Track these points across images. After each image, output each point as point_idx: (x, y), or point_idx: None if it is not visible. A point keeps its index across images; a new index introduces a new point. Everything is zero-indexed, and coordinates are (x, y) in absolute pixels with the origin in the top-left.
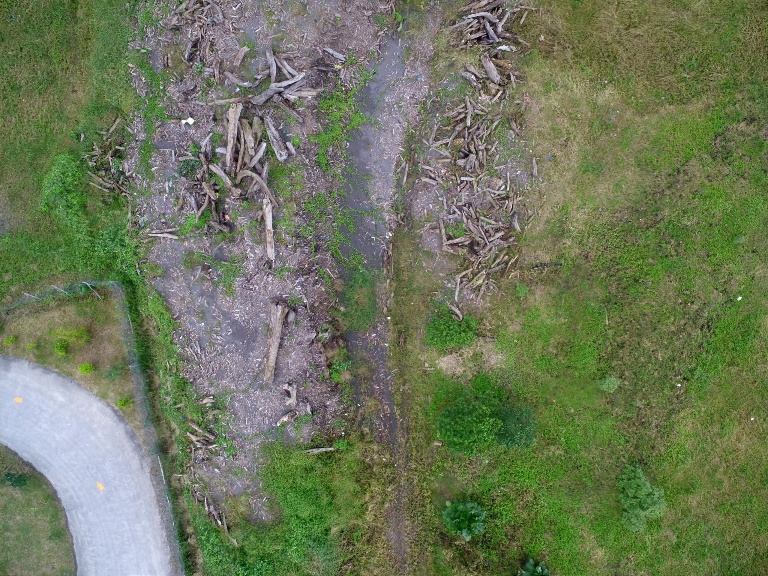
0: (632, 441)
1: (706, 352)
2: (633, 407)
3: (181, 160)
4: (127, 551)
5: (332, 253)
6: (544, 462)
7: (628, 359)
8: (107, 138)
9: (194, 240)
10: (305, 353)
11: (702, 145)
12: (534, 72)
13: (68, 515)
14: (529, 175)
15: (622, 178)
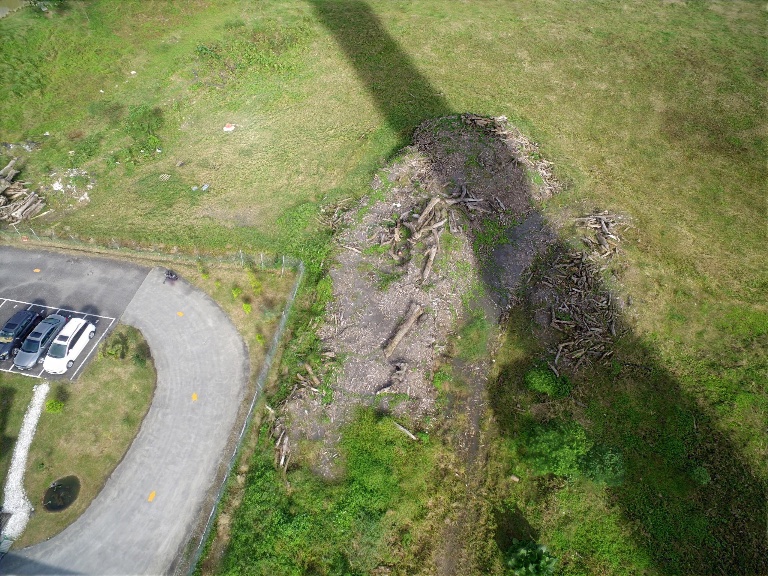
0: (730, 551)
1: None
2: (728, 513)
3: (383, 220)
4: (177, 463)
5: (462, 302)
6: (627, 540)
7: (719, 464)
8: (340, 202)
9: (372, 257)
10: (422, 349)
11: None
12: (633, 255)
13: (151, 410)
14: (626, 304)
15: (703, 331)
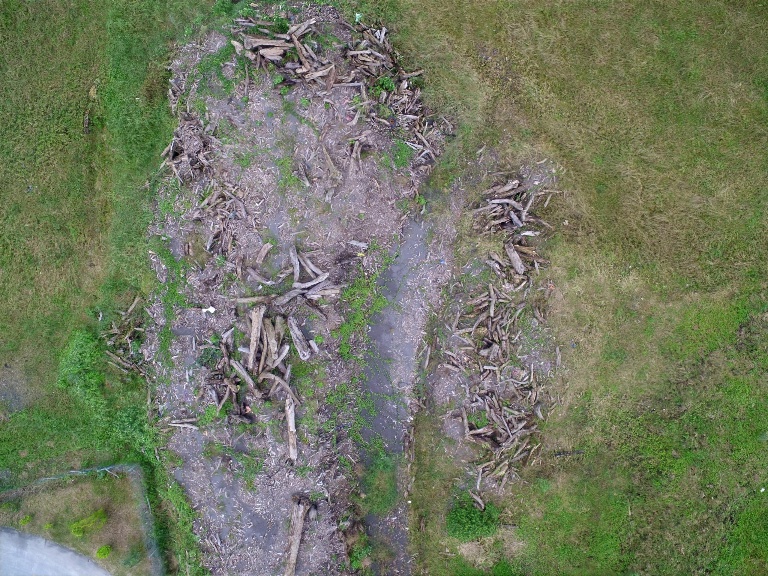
0: None
1: (728, 543)
2: None
3: (202, 349)
4: None
5: (353, 438)
6: None
7: (651, 552)
8: (126, 318)
9: (215, 431)
10: (326, 546)
11: (727, 335)
12: (558, 256)
13: None
14: (552, 364)
15: (646, 366)
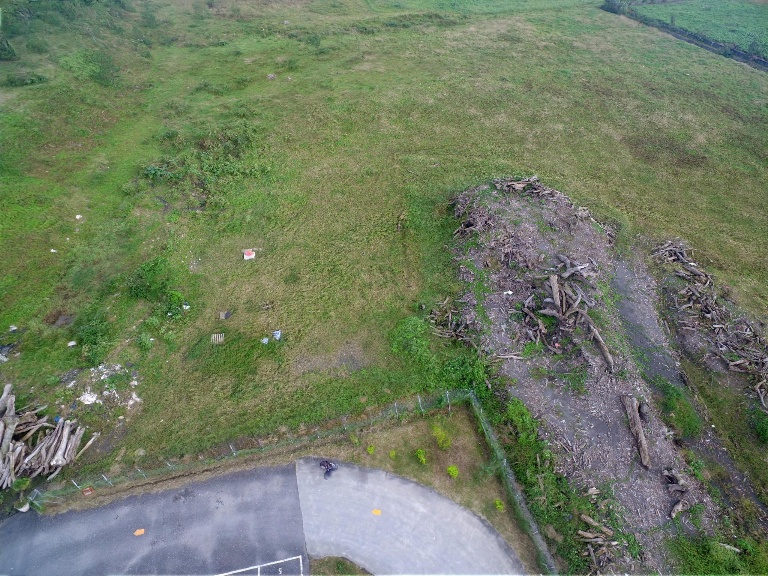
0: None
1: None
2: None
3: (509, 313)
4: None
5: (641, 375)
6: None
7: None
8: (443, 307)
9: (536, 359)
10: (666, 445)
11: None
12: (718, 276)
13: None
14: (759, 325)
15: None
